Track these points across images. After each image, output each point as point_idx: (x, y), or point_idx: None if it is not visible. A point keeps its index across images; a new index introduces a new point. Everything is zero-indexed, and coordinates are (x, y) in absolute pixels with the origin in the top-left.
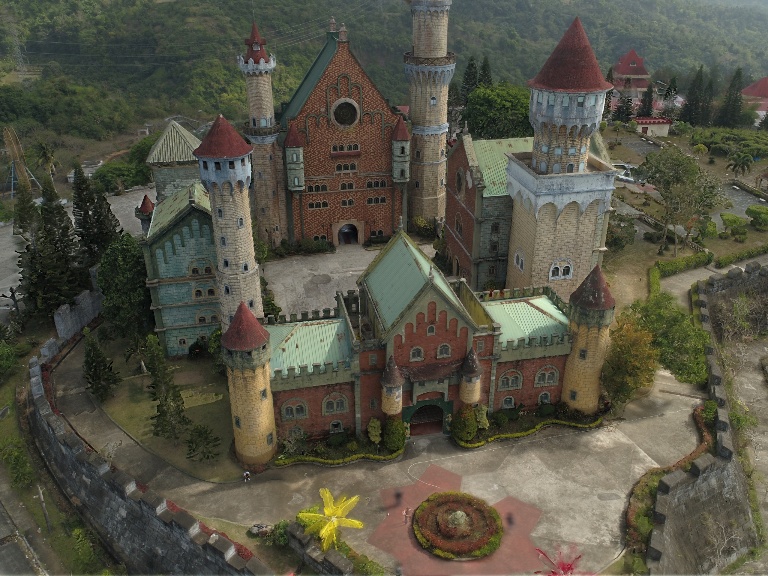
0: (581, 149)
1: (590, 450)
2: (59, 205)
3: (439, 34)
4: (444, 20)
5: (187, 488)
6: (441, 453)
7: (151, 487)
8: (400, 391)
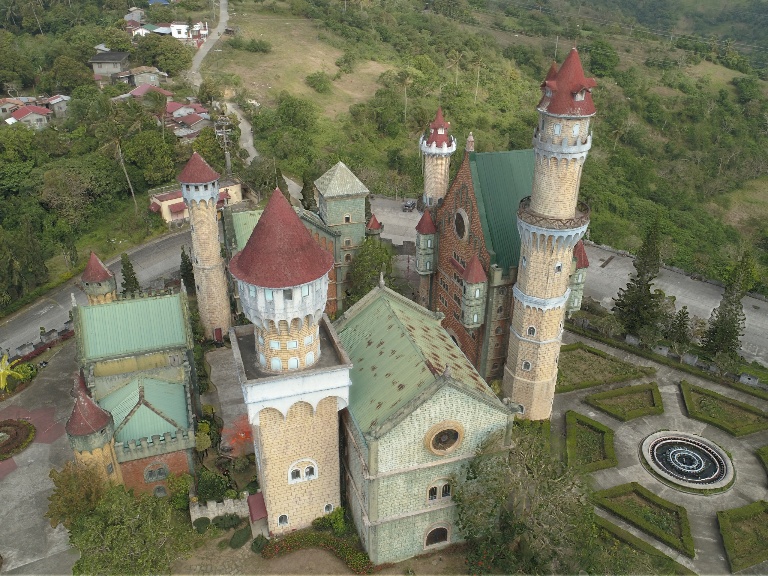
0: None
1: None
2: (311, 189)
3: (541, 184)
4: (552, 169)
5: None
6: None
7: None
8: None
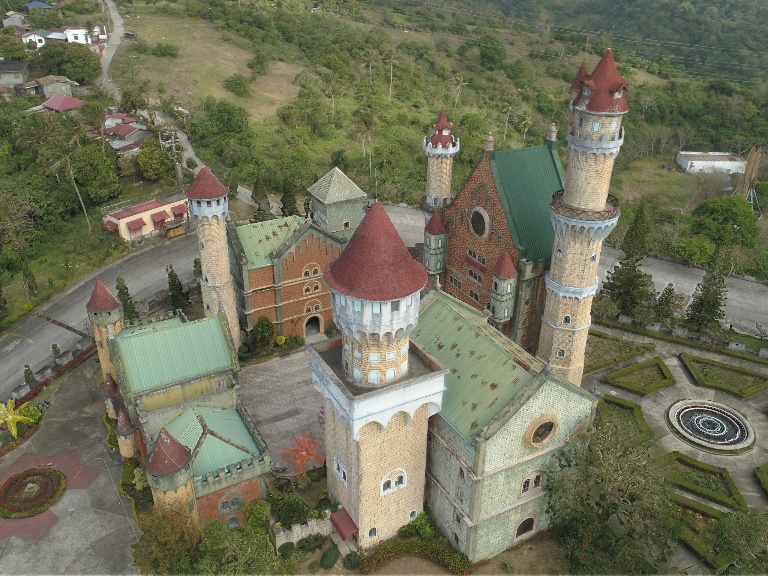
0: (355, 352)
1: (118, 571)
2: (292, 196)
3: (579, 179)
4: (590, 164)
5: (89, 369)
6: (116, 472)
7: (92, 357)
8: (108, 402)
